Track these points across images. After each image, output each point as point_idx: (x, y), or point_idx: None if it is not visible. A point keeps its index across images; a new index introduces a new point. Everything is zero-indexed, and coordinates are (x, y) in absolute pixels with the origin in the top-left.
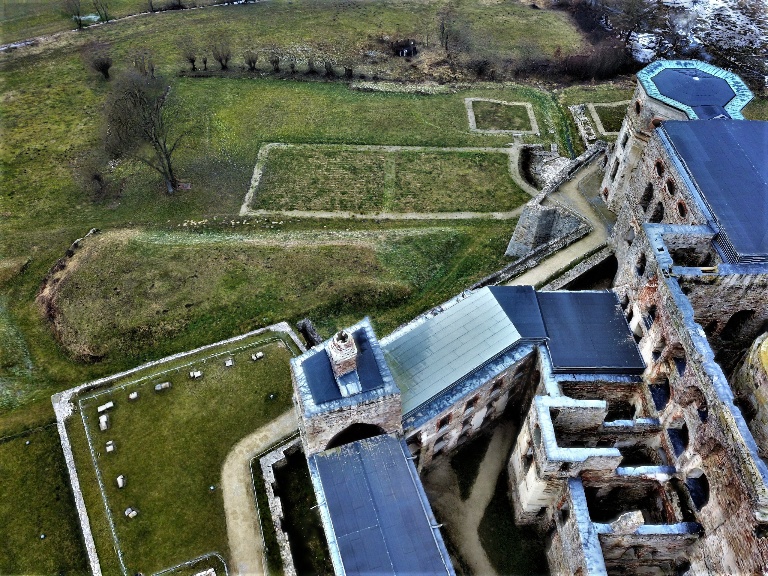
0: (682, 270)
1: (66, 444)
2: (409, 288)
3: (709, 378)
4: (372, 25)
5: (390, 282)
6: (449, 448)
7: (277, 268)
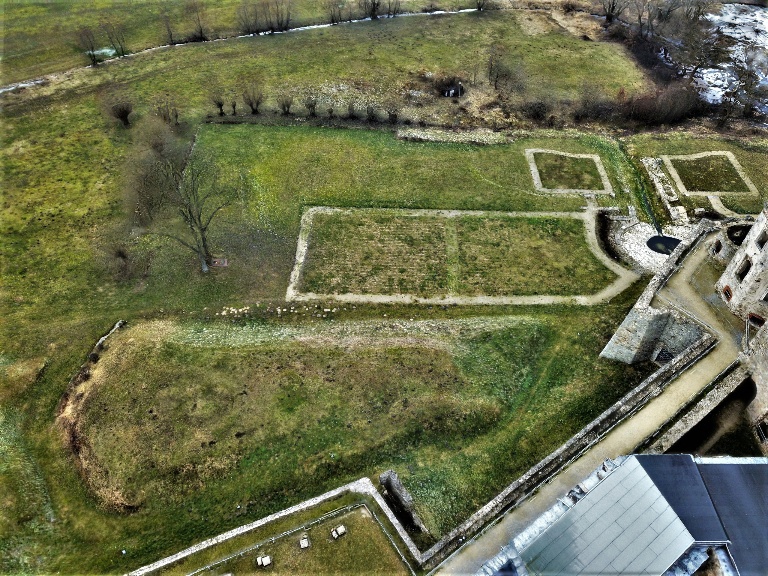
0: None
1: None
2: (497, 407)
3: None
4: (412, 59)
5: (475, 400)
6: None
7: (340, 382)
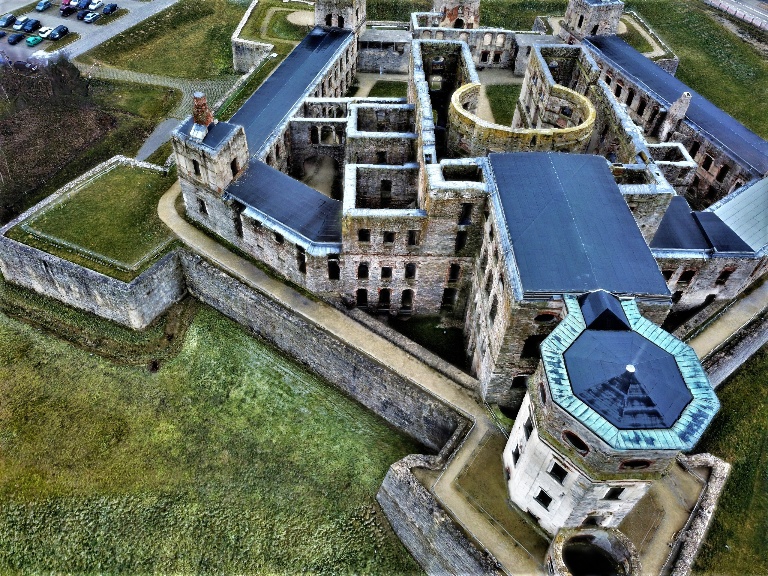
0: (638, 166)
1: None
2: None
3: None
4: None
5: None
6: None
7: None
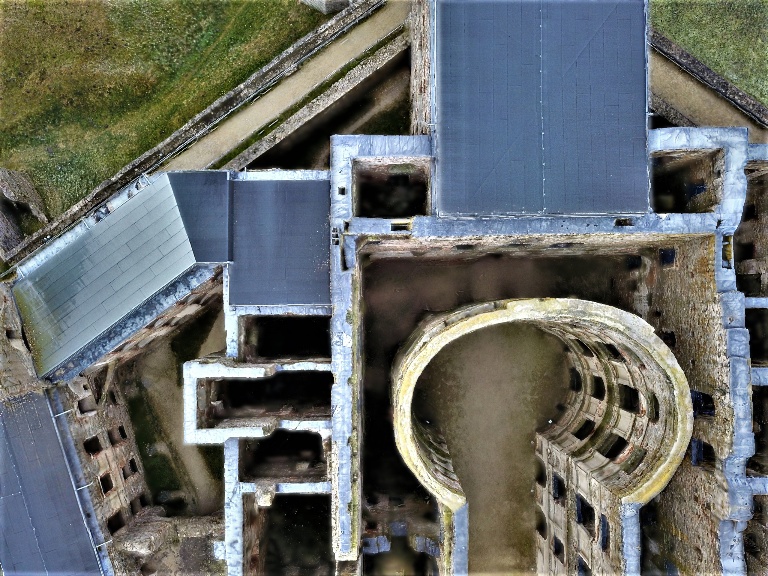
0: (363, 226)
1: None
2: (153, 76)
3: None
4: None
5: (125, 69)
6: (165, 333)
7: None
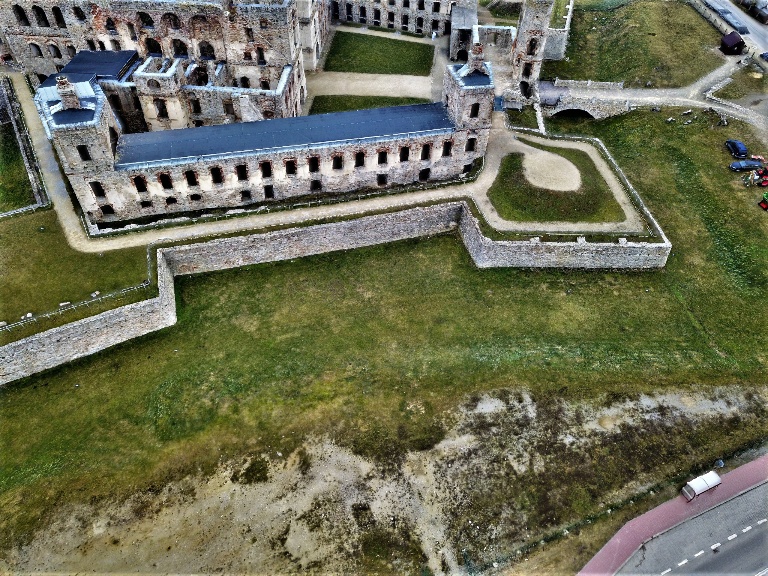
0: None
1: (5, 347)
2: None
3: (162, 2)
4: None
5: None
6: None
7: None
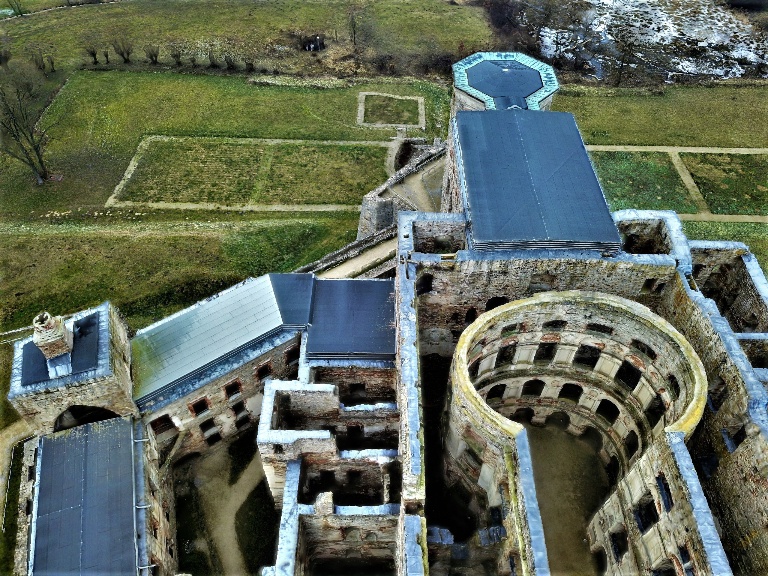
0: (421, 256)
1: None
2: None
3: (400, 361)
4: (286, 20)
5: (227, 272)
6: (227, 434)
7: (116, 258)
